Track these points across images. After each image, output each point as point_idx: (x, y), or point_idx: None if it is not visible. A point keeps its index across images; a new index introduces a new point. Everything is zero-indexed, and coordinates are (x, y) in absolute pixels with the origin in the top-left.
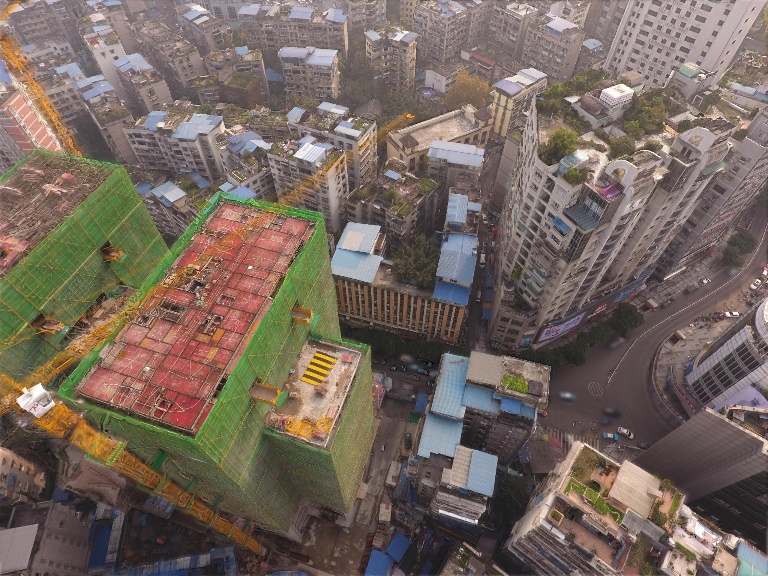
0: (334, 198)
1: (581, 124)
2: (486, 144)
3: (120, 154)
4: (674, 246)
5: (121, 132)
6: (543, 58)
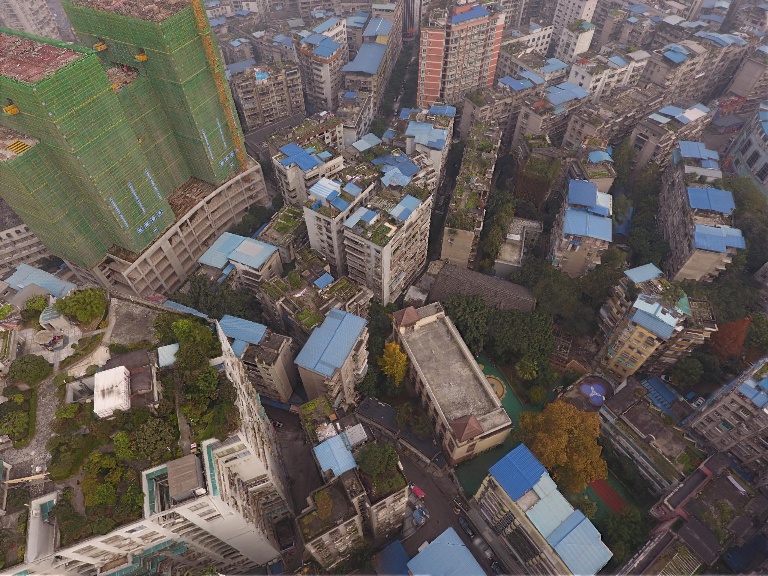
0: (314, 238)
1: (121, 353)
2: None
3: (461, 125)
4: None
5: None
6: None
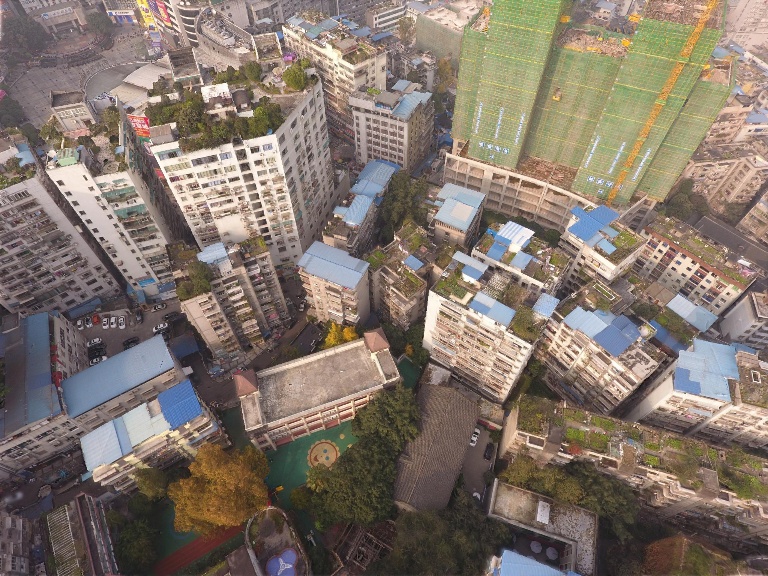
0: None
1: None
2: None
3: None
4: None
5: None
6: (3, 566)
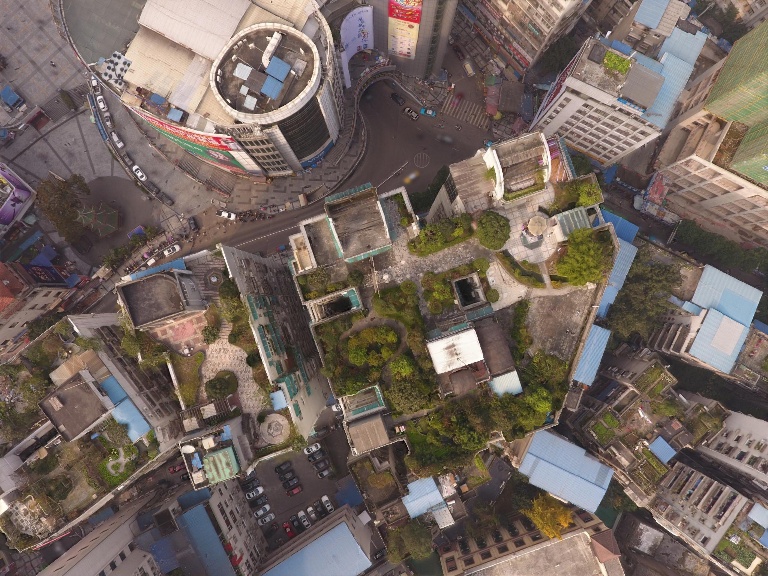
0: (746, 426)
1: None
2: (428, 572)
3: None
4: (283, 276)
5: None
6: None
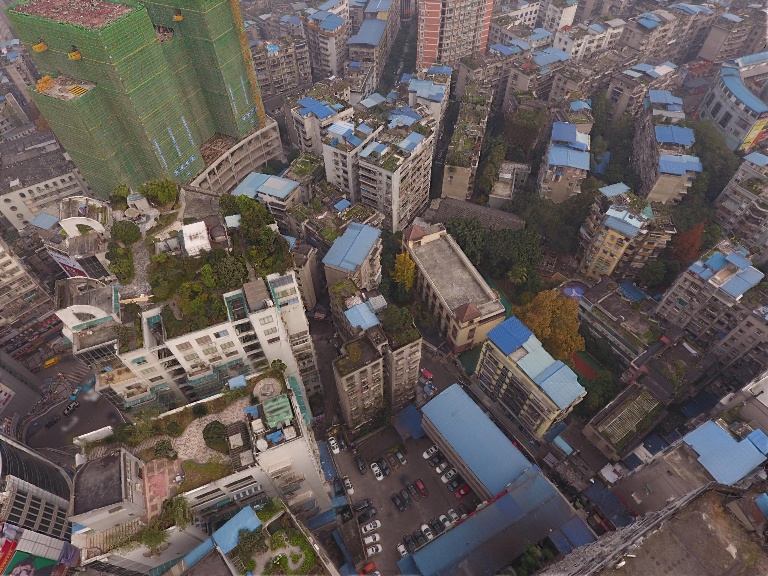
0: (331, 174)
1: None
2: None
3: (457, 89)
4: None
5: (464, 76)
6: None
